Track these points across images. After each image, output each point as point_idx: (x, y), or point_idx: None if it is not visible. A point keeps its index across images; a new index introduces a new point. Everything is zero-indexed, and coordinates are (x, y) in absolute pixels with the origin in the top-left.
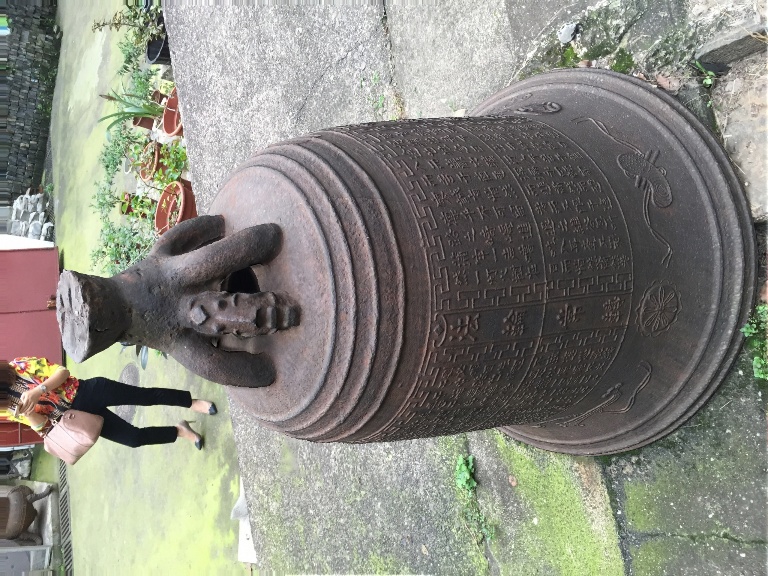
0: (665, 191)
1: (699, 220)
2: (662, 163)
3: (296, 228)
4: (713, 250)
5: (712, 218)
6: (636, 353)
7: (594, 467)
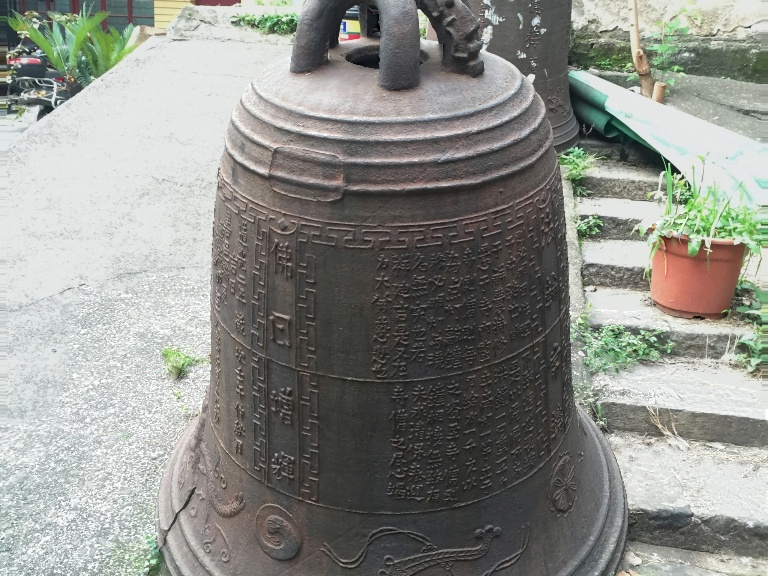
0: None
1: (598, 467)
2: None
3: None
4: (603, 496)
5: (607, 475)
6: (533, 505)
7: None
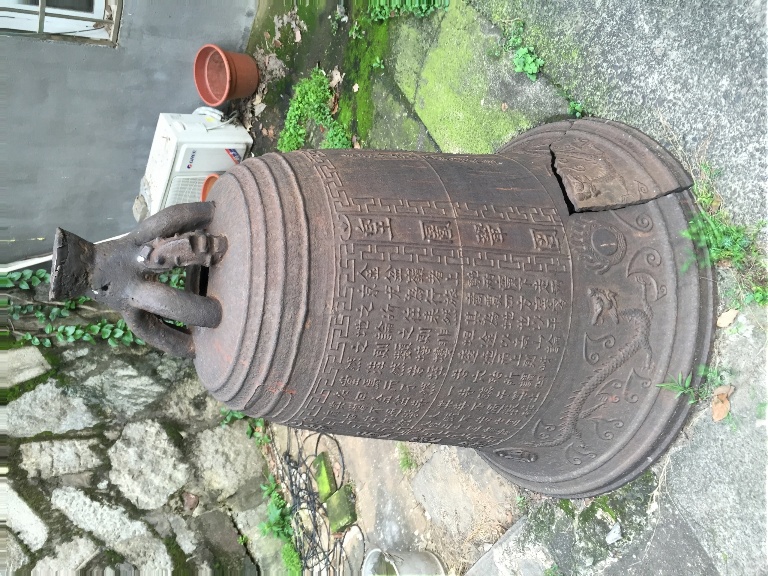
0: None
1: None
2: None
3: None
4: None
5: None
6: None
7: None
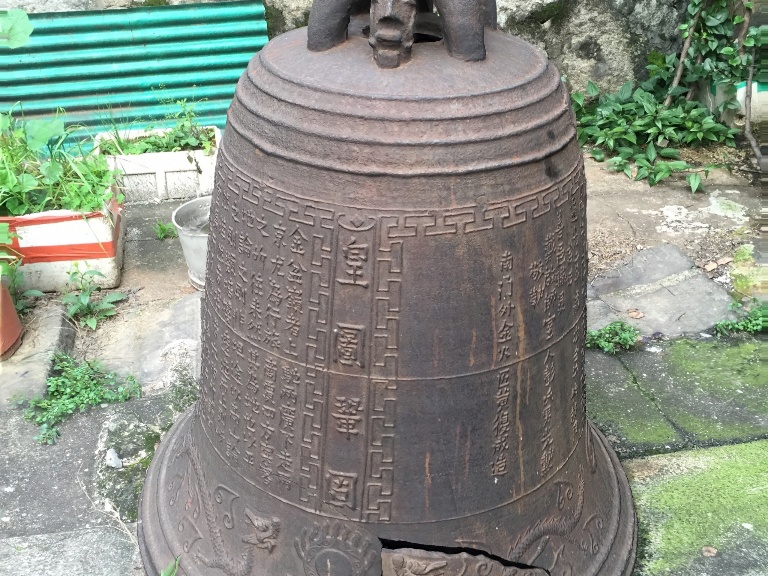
0: None
1: None
2: None
3: None
4: None
5: None
6: None
7: (629, 464)
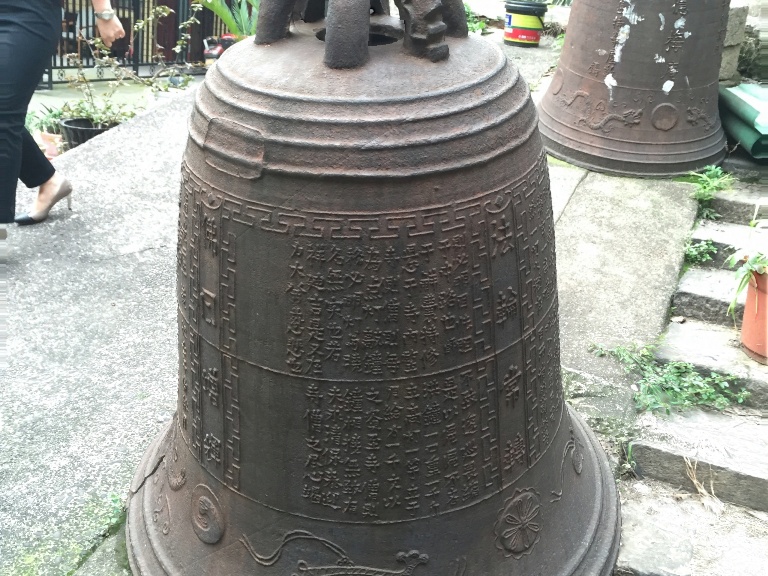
0: (579, 464)
1: (585, 513)
2: (583, 453)
3: (482, 45)
4: (580, 544)
5: (594, 523)
6: (473, 538)
7: None
